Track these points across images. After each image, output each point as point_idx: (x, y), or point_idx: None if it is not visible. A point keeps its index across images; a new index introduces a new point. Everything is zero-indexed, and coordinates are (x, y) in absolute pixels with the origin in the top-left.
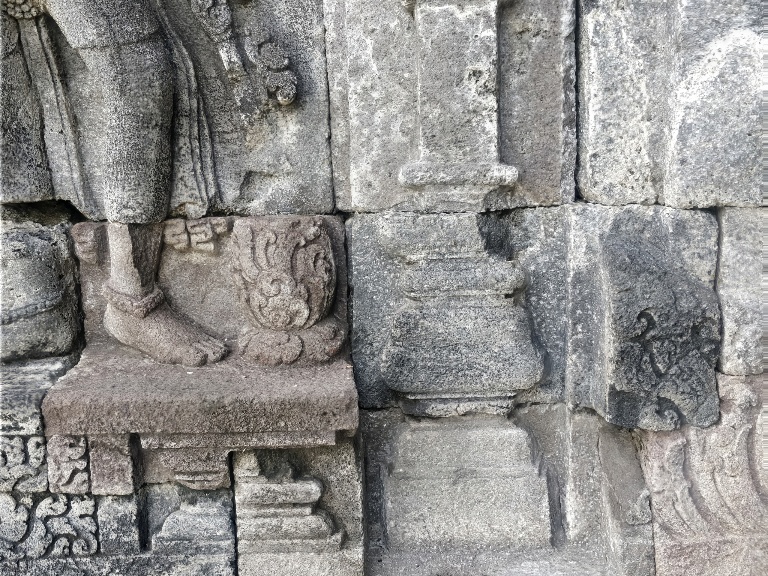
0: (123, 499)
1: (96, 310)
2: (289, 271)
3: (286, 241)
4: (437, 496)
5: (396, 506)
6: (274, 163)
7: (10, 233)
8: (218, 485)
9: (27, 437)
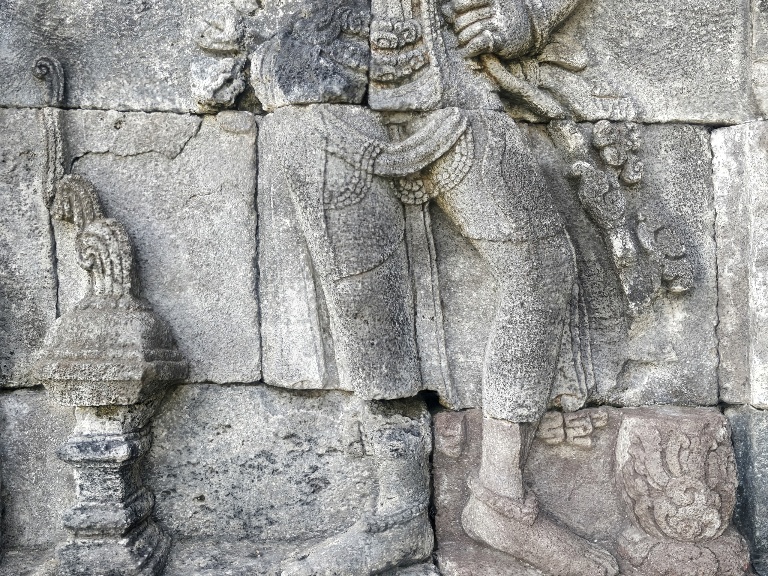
0: None
1: (450, 506)
2: (703, 478)
3: (700, 445)
4: None
5: None
6: (655, 351)
7: (383, 430)
8: None
9: None
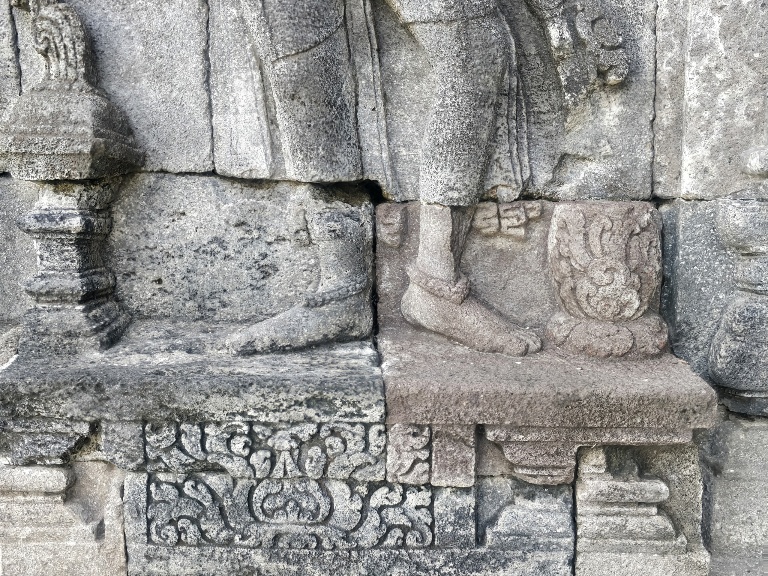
0: (461, 491)
1: (391, 294)
2: (624, 259)
3: (622, 228)
4: (767, 499)
5: (723, 508)
6: (592, 146)
7: (323, 213)
8: (561, 481)
9: (368, 424)
